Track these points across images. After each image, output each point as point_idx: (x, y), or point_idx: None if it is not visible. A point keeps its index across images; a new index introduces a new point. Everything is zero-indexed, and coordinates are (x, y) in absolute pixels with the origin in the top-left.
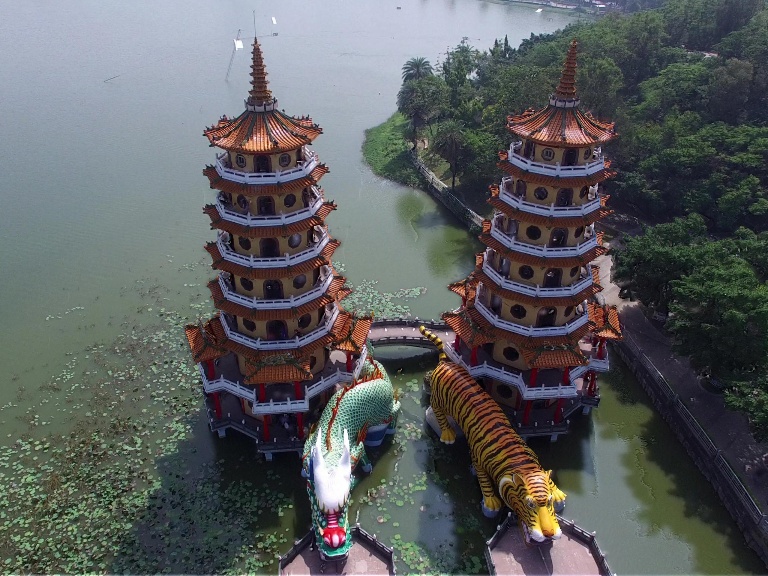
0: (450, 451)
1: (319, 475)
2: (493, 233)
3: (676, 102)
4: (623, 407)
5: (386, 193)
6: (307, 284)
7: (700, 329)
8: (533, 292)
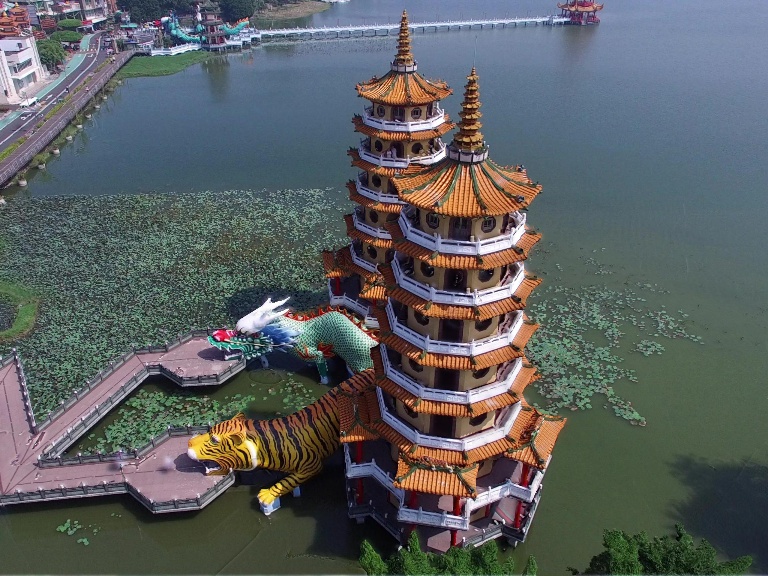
0: None
1: None
2: None
3: None
4: None
5: None
6: (378, 223)
7: None
8: None
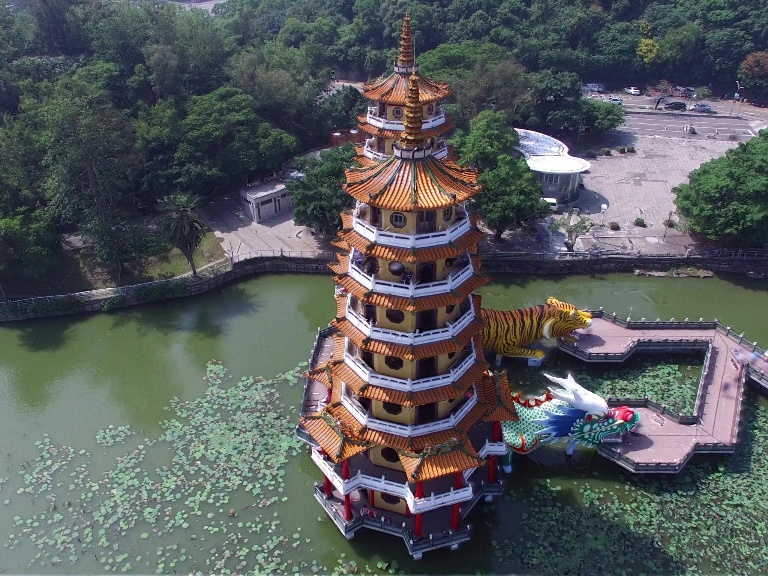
0: None
1: (589, 401)
2: None
3: None
4: None
5: None
6: None
7: None
8: None
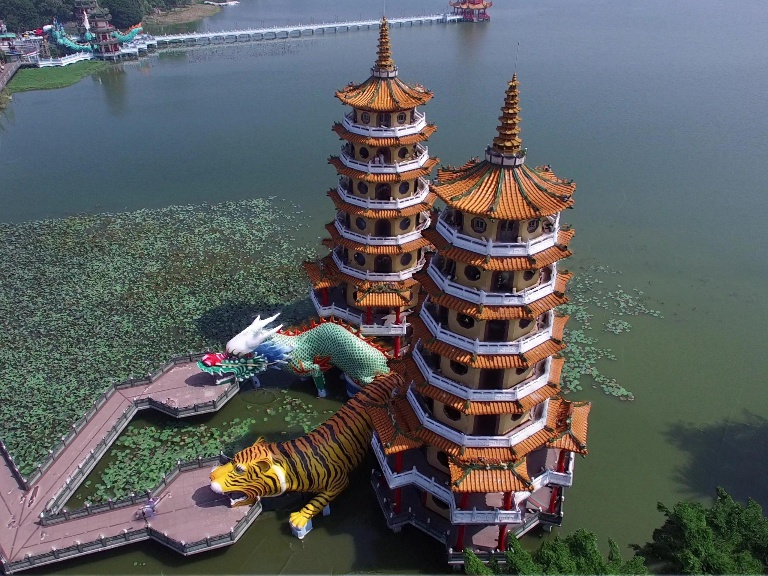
0: None
1: None
2: None
3: None
4: None
5: None
6: (366, 230)
7: None
8: None
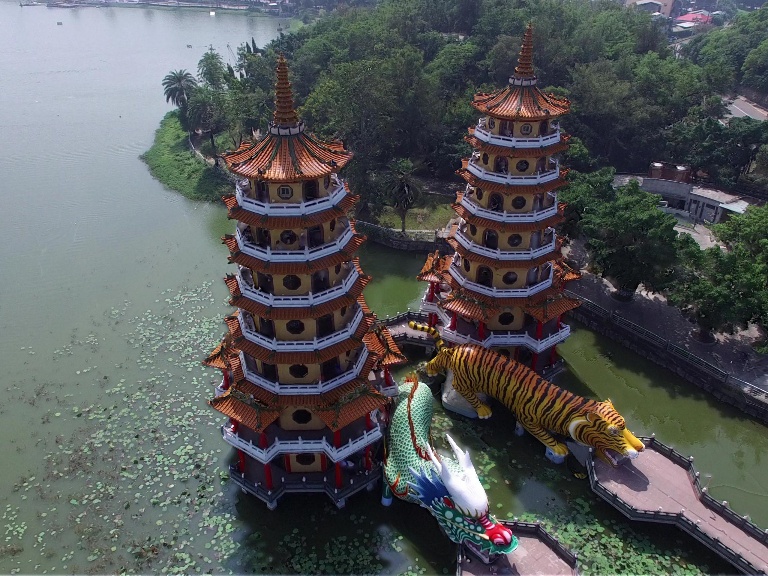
0: (487, 425)
1: (456, 486)
2: (477, 213)
3: (456, 78)
4: (571, 337)
5: (216, 215)
6: (348, 309)
7: (624, 252)
8: (528, 256)
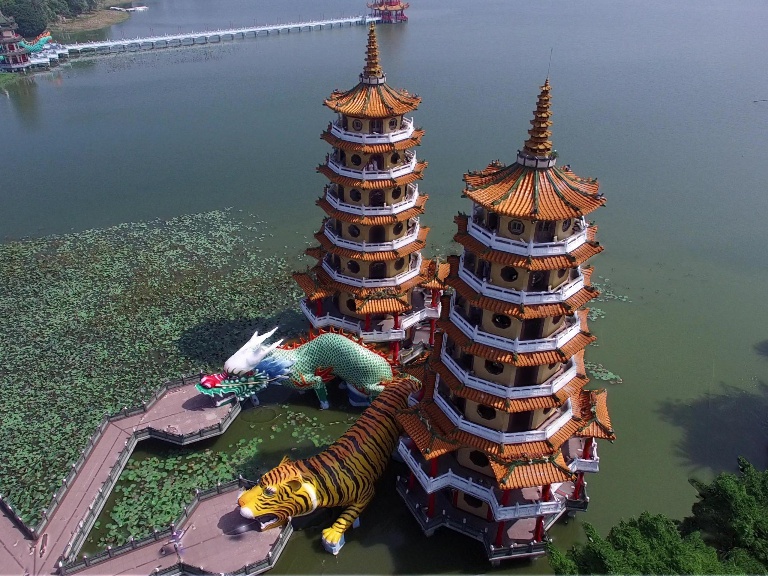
0: None
1: None
2: None
3: None
4: None
5: None
6: (360, 237)
7: None
8: None
